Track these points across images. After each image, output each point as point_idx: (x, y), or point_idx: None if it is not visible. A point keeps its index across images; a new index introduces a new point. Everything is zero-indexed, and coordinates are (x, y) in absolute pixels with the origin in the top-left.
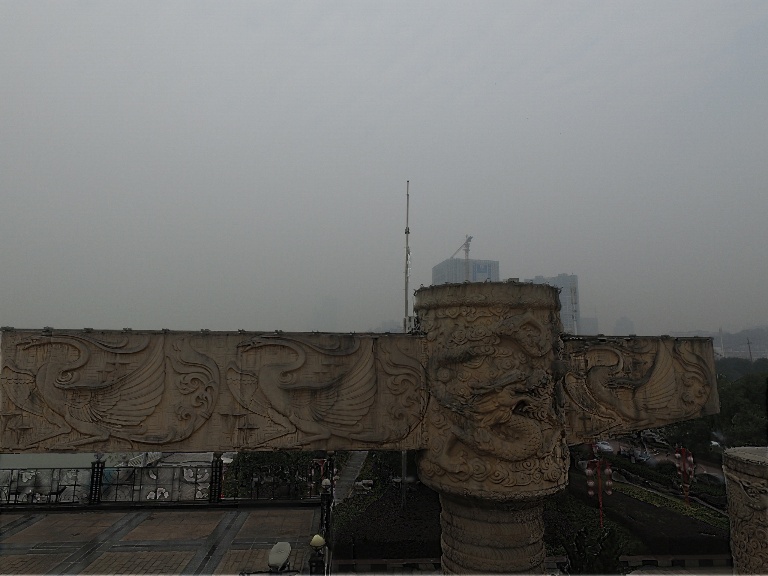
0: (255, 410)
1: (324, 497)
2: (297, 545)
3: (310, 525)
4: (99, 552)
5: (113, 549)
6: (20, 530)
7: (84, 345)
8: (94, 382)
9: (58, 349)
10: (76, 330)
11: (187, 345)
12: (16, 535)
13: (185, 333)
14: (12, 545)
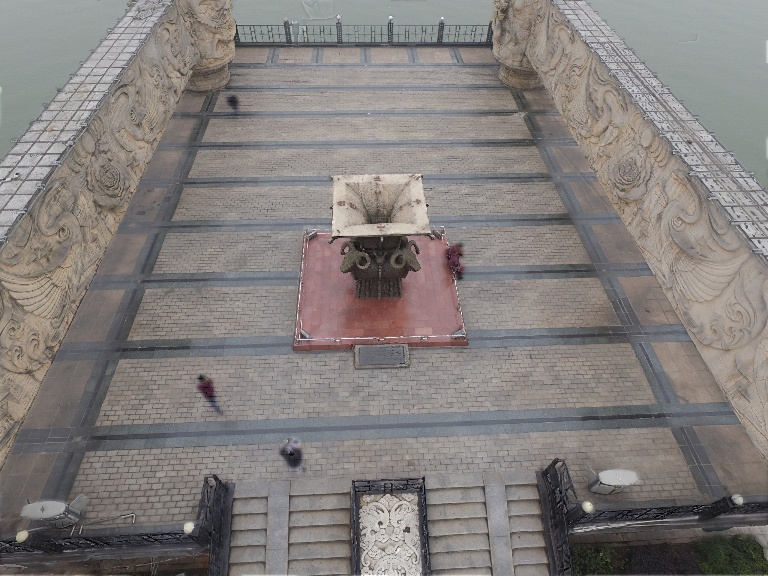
0: (759, 389)
1: (724, 501)
2: (705, 487)
3: (757, 493)
4: (629, 340)
5: (637, 346)
6: (638, 275)
7: (700, 208)
8: (687, 243)
9: (688, 196)
10: (704, 191)
11: (759, 281)
12: (631, 278)
13: (767, 269)
14: (618, 286)
